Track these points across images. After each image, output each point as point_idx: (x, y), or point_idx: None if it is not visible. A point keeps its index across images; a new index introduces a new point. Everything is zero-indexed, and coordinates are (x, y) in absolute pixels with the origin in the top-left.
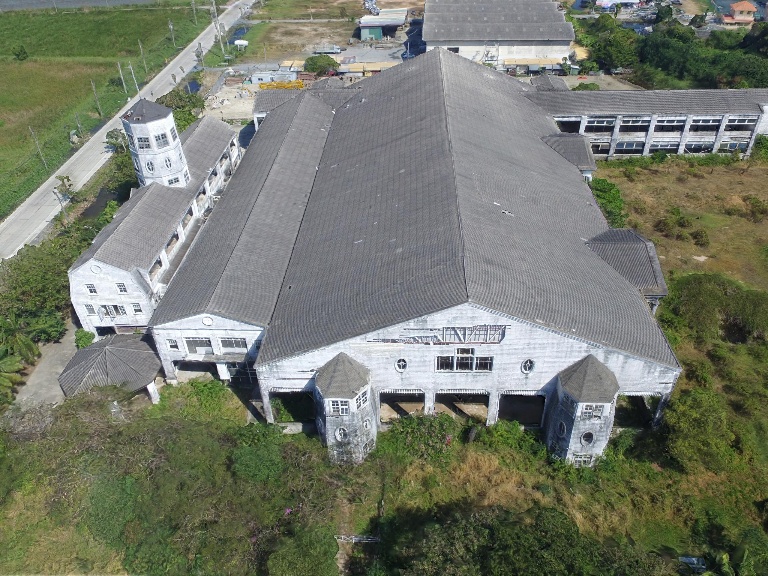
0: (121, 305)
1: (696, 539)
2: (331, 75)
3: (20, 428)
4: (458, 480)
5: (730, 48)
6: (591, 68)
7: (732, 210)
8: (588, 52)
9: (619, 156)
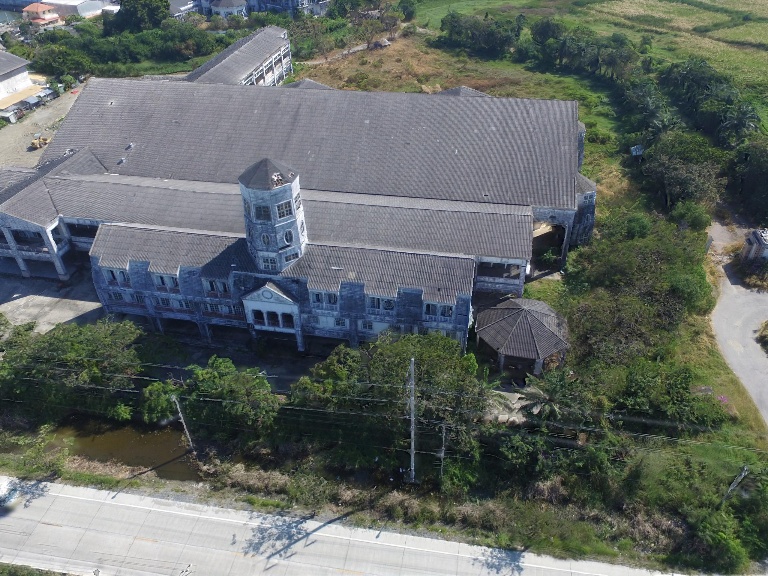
0: None
1: (616, 155)
2: None
3: None
4: None
5: (106, 35)
6: (69, 82)
7: None
8: (33, 74)
9: None
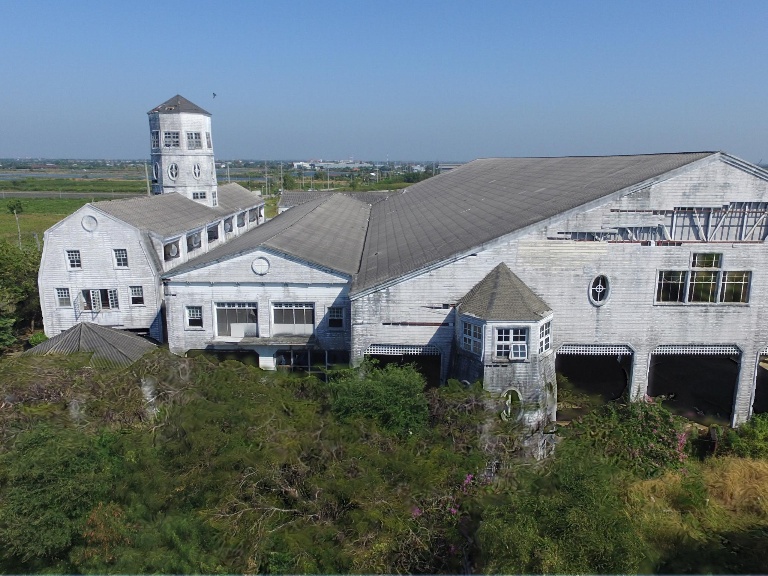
0: (113, 289)
1: None
2: None
3: None
4: (731, 501)
5: None
6: None
7: None
8: None
9: None
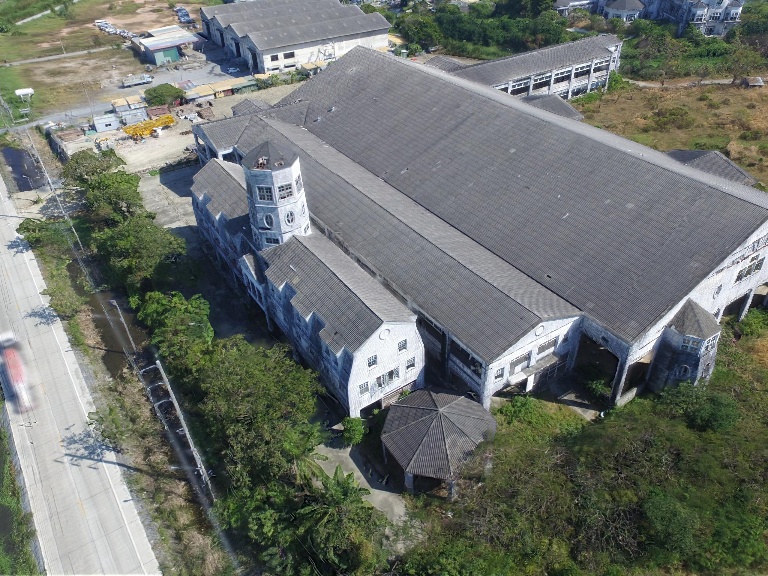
0: (396, 368)
1: None
2: (178, 104)
3: (401, 547)
4: (767, 366)
5: (491, 17)
6: (416, 50)
7: (648, 128)
8: (398, 37)
9: None
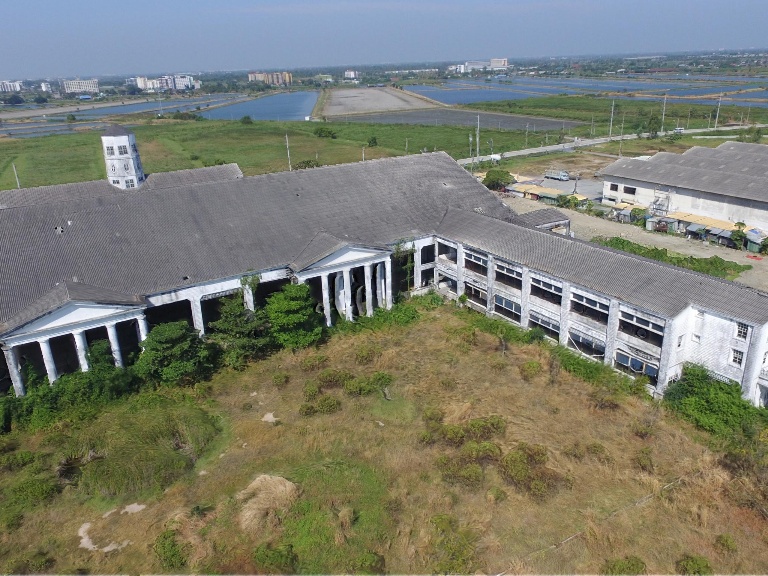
0: None
1: None
2: None
3: None
4: None
5: None
6: None
7: None
8: None
9: (498, 316)
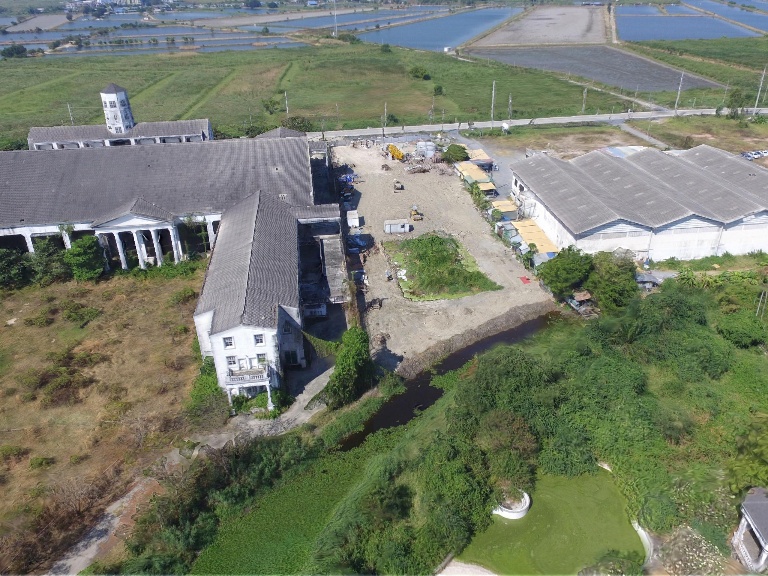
0: None
1: None
2: None
3: None
4: None
5: None
6: None
7: None
8: None
9: None
